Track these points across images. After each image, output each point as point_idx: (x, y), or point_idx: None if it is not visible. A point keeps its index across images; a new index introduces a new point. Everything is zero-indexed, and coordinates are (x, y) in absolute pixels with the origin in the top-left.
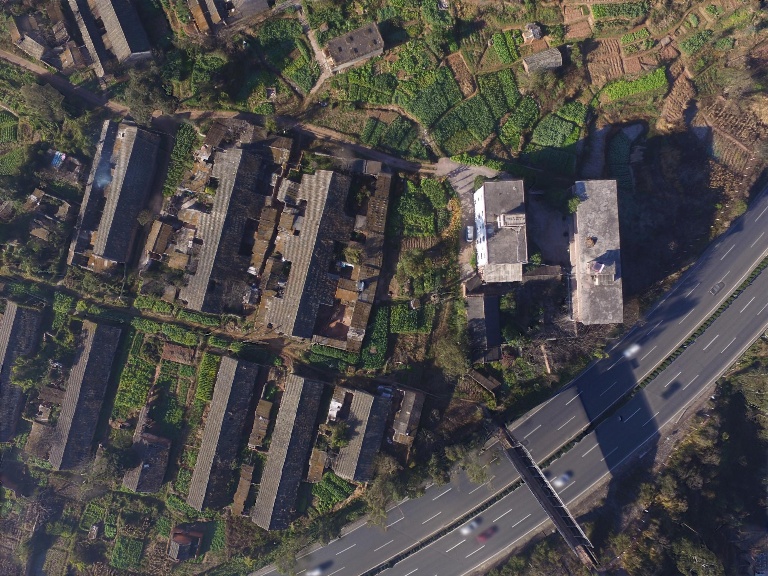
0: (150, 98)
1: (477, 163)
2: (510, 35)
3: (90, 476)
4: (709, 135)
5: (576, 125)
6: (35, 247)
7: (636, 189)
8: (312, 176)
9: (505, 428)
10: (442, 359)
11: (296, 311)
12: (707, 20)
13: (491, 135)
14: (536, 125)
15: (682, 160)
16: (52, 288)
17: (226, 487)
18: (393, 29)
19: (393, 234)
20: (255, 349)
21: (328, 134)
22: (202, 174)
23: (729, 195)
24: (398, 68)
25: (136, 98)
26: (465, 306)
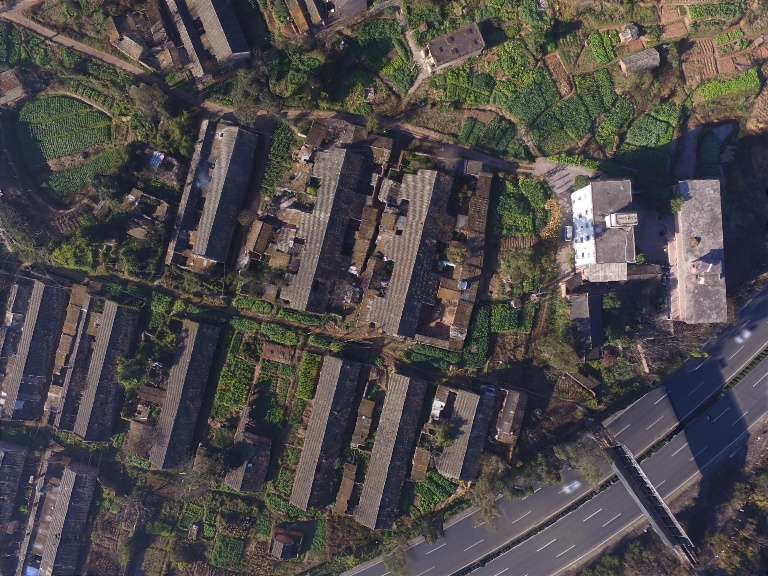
0: (260, 98)
1: (574, 163)
2: (607, 35)
3: (190, 475)
4: None
5: (670, 125)
6: (138, 247)
7: (726, 189)
8: (414, 176)
9: (603, 427)
10: (541, 358)
11: (401, 310)
12: None
13: (588, 135)
14: (630, 125)
15: None
16: (149, 288)
17: (329, 486)
18: (492, 29)
19: (492, 234)
20: (356, 348)
21: (426, 134)
22: (302, 174)
23: None
24: (496, 68)
25: (245, 98)
26: (568, 305)
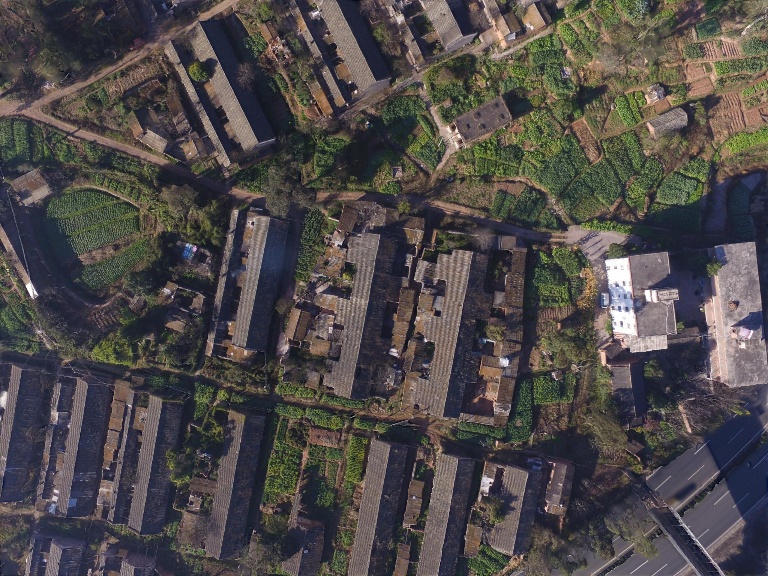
0: (293, 194)
1: (607, 229)
2: (633, 97)
3: (246, 561)
4: None
5: (699, 181)
6: (179, 344)
7: (757, 239)
8: (449, 256)
9: (649, 489)
10: (584, 426)
11: (446, 393)
12: None
13: (618, 199)
14: (660, 184)
15: None
16: (191, 378)
17: (385, 567)
18: (517, 100)
19: (529, 306)
20: (402, 429)
21: (457, 210)
22: (337, 259)
23: None
24: (524, 139)
25: (278, 195)
26: (610, 376)
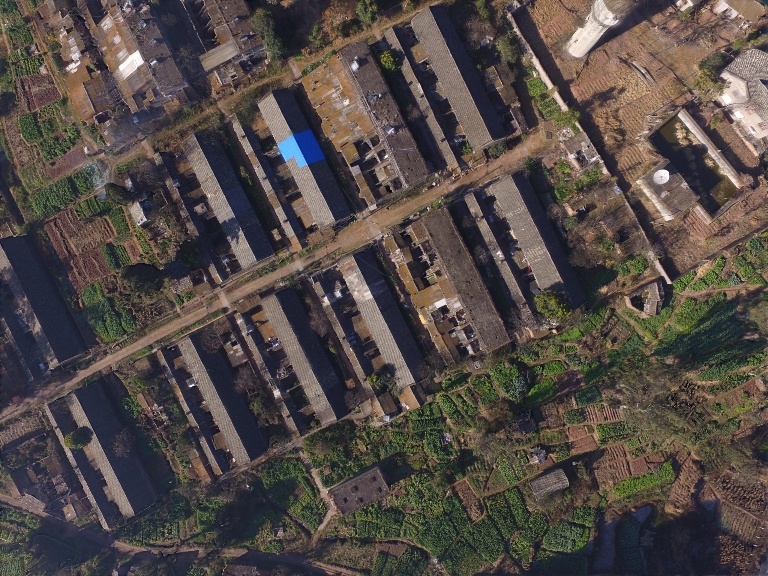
0: None
1: None
2: None
3: None
4: (718, 506)
5: (585, 527)
6: None
7: (647, 571)
8: None
9: None
10: None
11: None
12: (712, 416)
13: (501, 555)
14: (545, 532)
15: (692, 539)
16: None
17: None
18: (397, 467)
19: None
20: None
21: (339, 570)
22: None
23: (740, 566)
24: (405, 503)
25: None
26: None
